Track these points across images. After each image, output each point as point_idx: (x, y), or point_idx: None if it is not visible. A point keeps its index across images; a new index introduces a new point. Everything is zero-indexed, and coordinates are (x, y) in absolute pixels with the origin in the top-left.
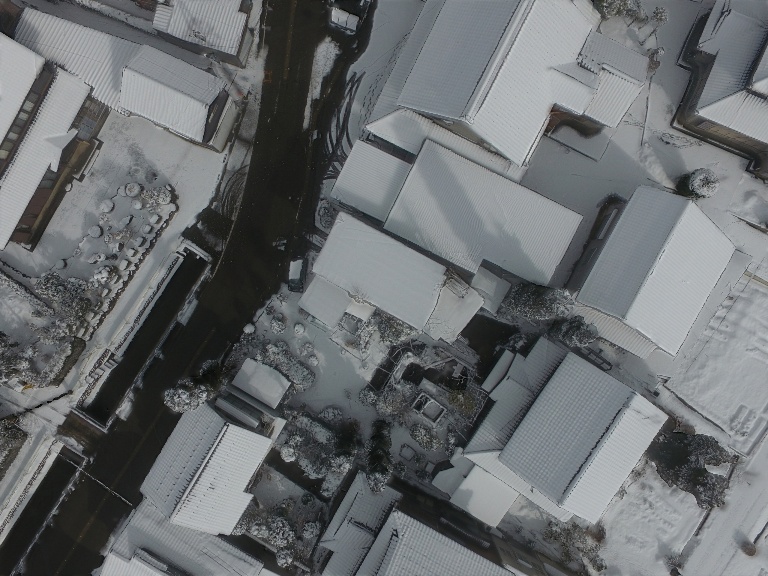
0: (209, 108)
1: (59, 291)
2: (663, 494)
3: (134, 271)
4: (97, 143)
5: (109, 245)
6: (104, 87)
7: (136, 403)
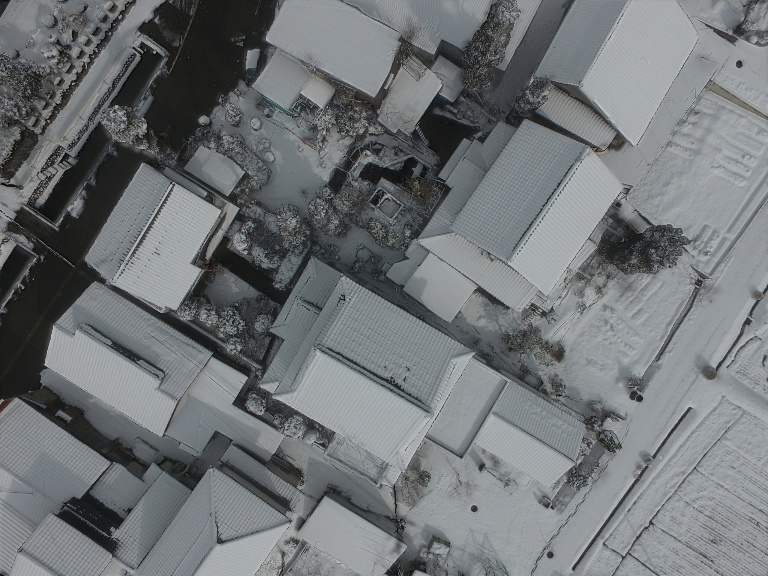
0: None
1: (8, 68)
2: (625, 317)
3: (89, 65)
4: None
5: (63, 36)
6: None
7: (89, 201)
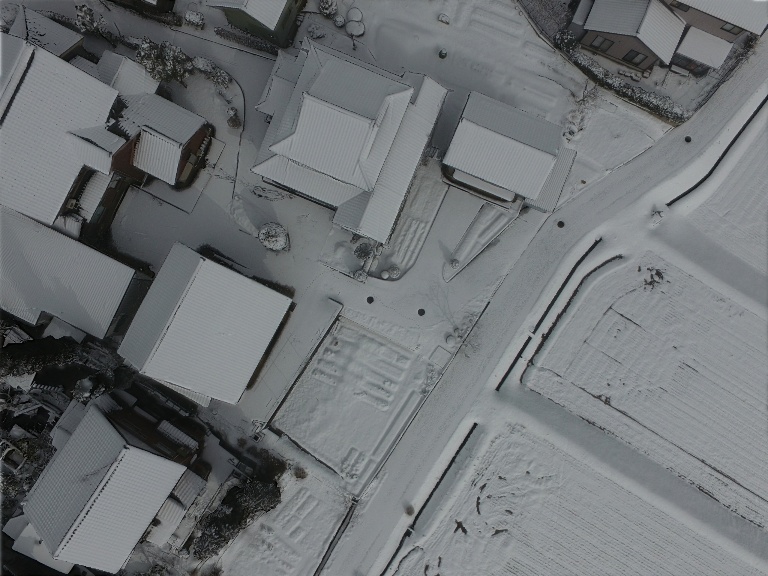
0: None
1: None
2: (283, 535)
3: None
4: None
5: None
6: None
7: None
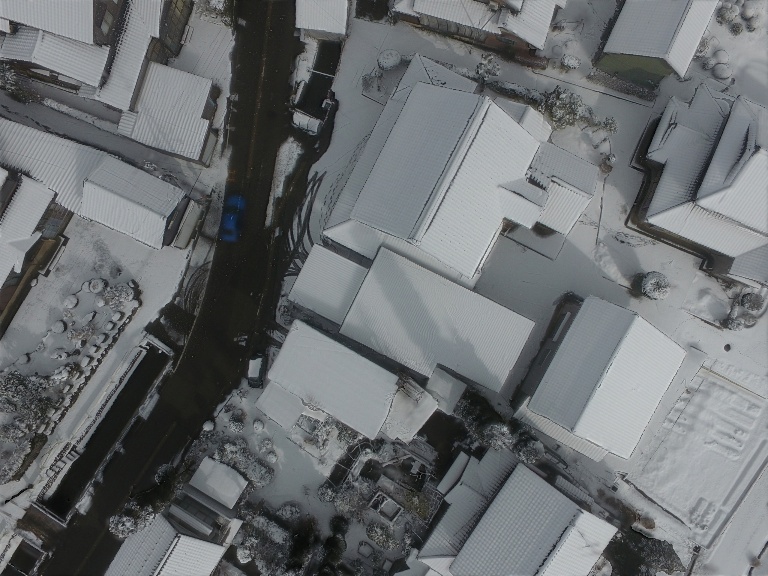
0: (167, 220)
1: (19, 391)
2: None
3: (97, 365)
4: (63, 240)
5: (72, 340)
6: (67, 193)
7: (96, 497)
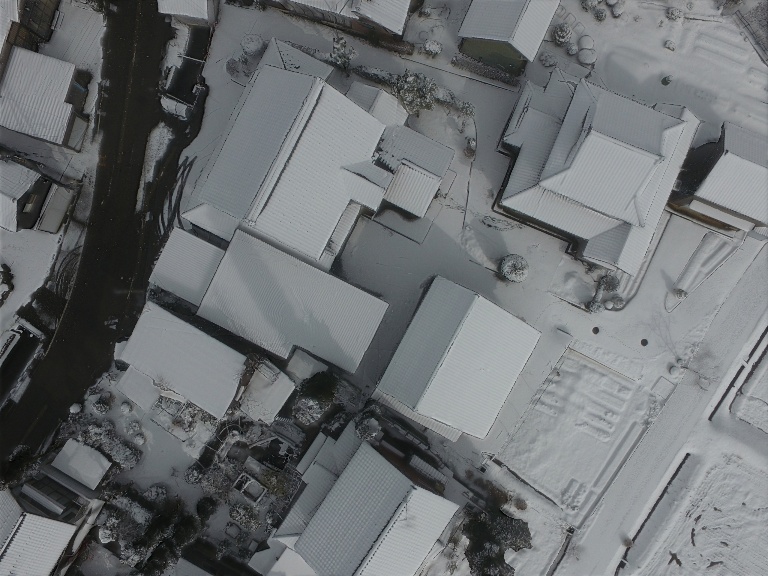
0: (18, 202)
1: None
2: None
3: None
4: None
5: None
6: None
7: None
